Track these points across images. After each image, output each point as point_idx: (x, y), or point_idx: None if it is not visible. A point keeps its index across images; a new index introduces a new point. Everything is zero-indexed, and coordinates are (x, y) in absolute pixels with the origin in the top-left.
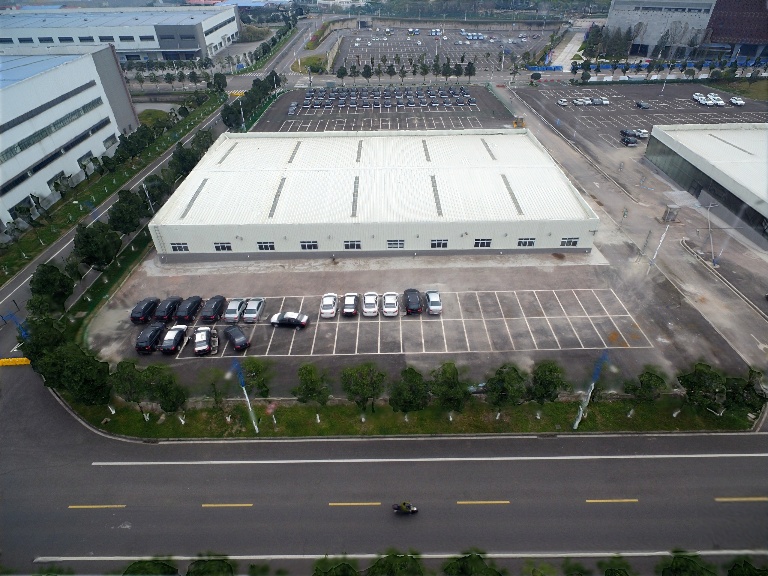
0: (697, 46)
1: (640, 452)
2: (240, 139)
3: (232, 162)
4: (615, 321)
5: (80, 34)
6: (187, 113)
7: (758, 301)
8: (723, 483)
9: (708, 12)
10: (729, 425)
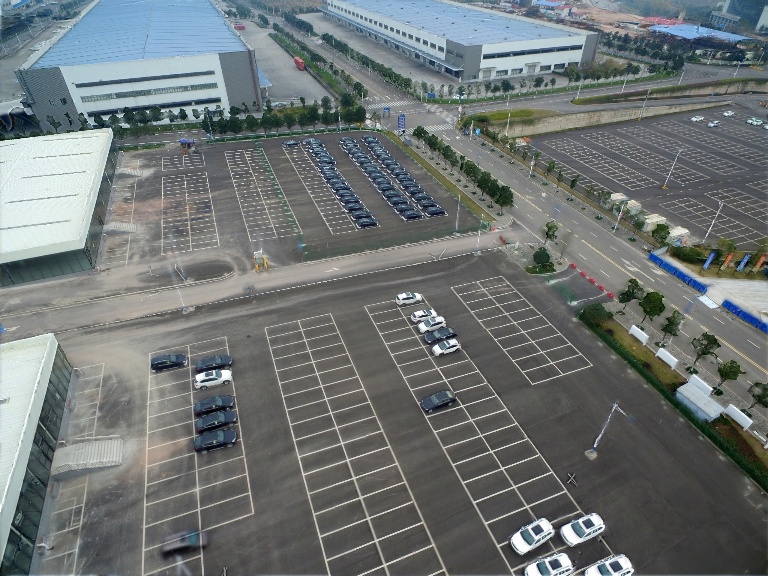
0: None
1: None
2: (105, 136)
3: (45, 143)
4: None
5: (417, 35)
6: (235, 113)
7: None
8: None
9: None
10: None
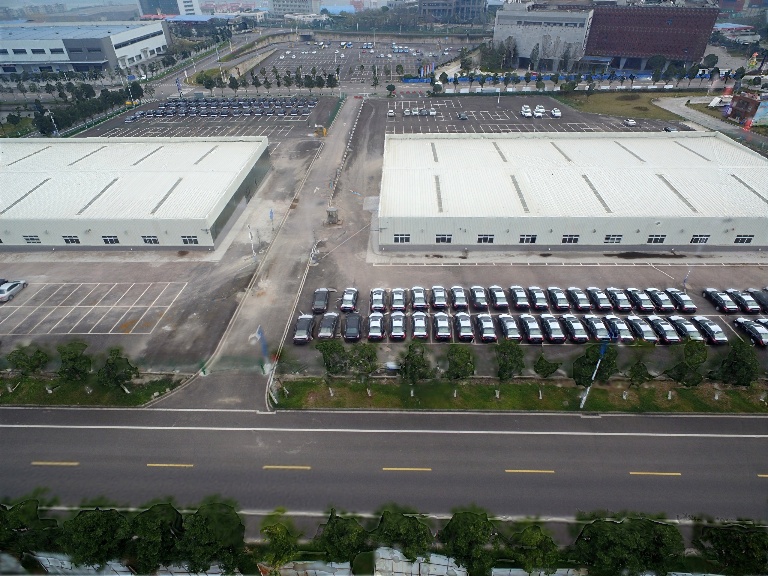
0: (577, 59)
1: (22, 422)
2: None
3: None
4: (149, 311)
5: None
6: (16, 120)
7: (306, 296)
8: (57, 450)
9: (583, 26)
10: (125, 401)
